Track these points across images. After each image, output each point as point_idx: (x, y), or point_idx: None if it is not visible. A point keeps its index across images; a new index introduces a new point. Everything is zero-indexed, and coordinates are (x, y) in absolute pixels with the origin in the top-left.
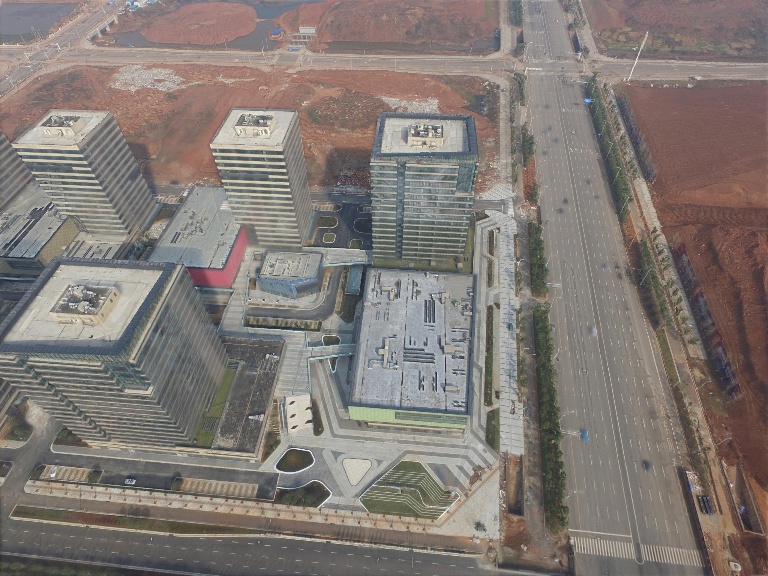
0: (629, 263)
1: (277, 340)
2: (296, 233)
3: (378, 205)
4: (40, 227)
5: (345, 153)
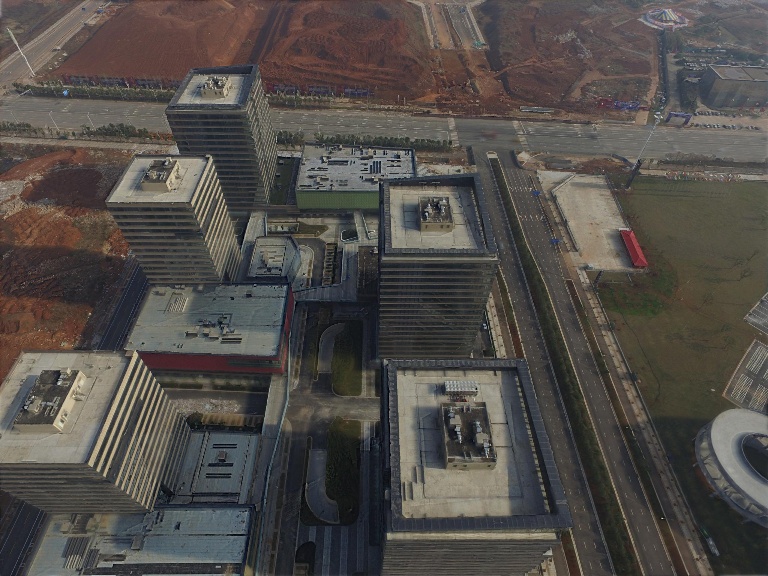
0: (275, 108)
1: (358, 251)
2: (237, 245)
3: (257, 149)
4: (170, 548)
5: (68, 249)
